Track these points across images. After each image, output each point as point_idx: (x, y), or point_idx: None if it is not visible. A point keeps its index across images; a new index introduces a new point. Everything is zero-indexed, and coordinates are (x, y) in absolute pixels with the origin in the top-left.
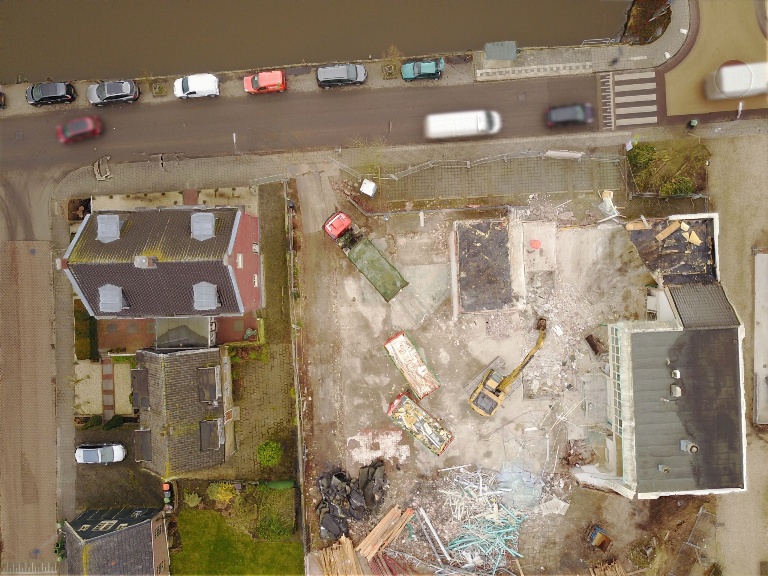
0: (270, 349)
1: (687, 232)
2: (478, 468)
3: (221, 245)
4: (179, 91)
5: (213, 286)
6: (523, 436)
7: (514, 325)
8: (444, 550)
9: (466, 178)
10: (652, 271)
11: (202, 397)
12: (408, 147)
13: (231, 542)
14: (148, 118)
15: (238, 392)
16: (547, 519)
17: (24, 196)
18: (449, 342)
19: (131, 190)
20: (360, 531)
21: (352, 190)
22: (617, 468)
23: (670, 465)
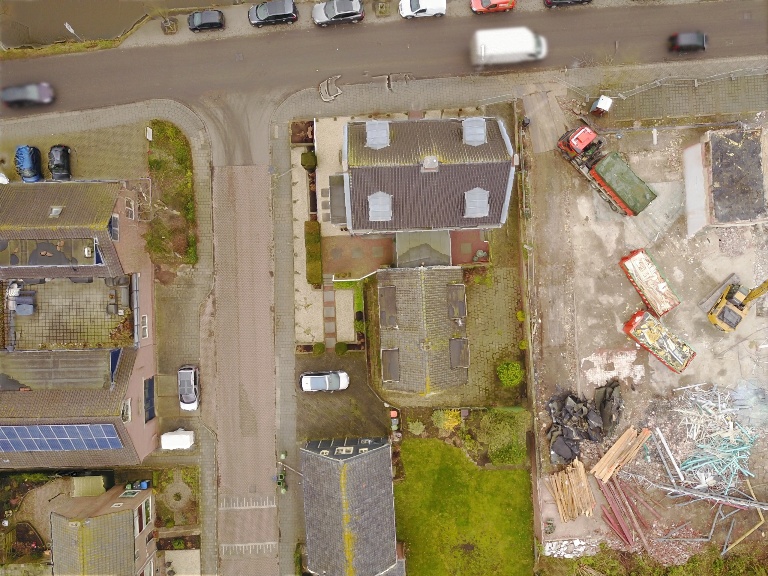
0: (494, 273)
1: None
2: (714, 386)
3: (497, 149)
4: (407, 10)
5: (485, 193)
6: (757, 353)
7: (747, 242)
8: (679, 470)
9: (693, 97)
10: None
11: (451, 314)
12: (635, 66)
13: (455, 471)
14: (371, 39)
15: None
16: None
17: (243, 119)
18: (683, 260)
19: (355, 112)
20: (591, 454)
21: (581, 109)
22: None
23: None
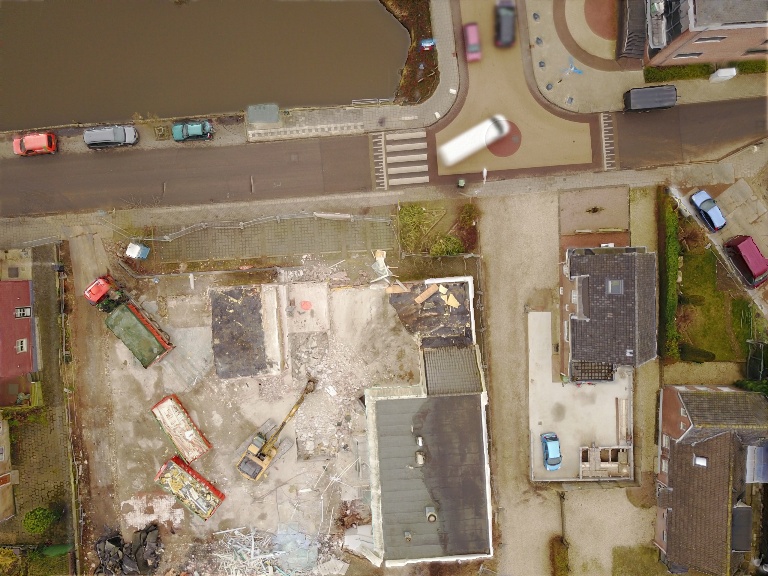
0: (49, 411)
1: (445, 295)
2: (252, 531)
3: None
4: None
5: None
6: (297, 498)
7: (286, 386)
8: None
9: (240, 239)
10: (412, 334)
11: None
12: (182, 208)
13: None
14: None
15: (17, 455)
16: None
17: None
18: (221, 404)
19: None
20: None
21: (124, 252)
22: None
23: (417, 532)
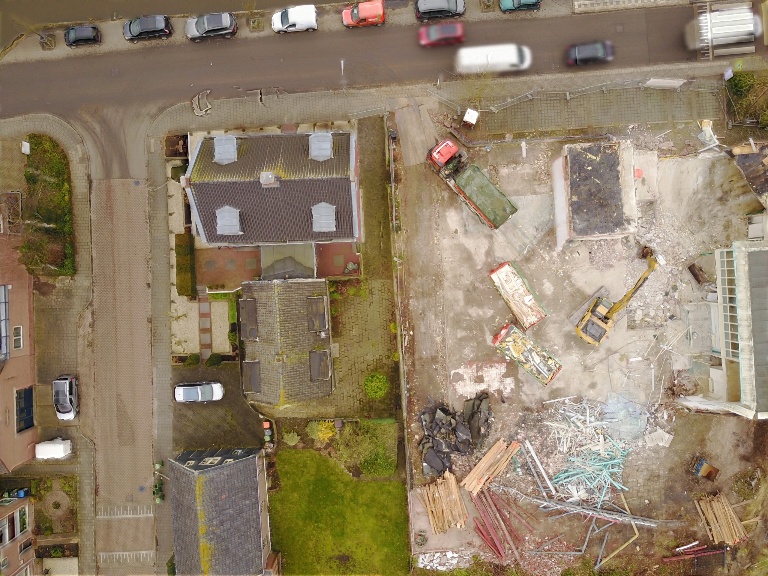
0: (368, 285)
1: None
2: (583, 399)
3: (341, 164)
4: (278, 25)
5: (332, 207)
6: (628, 366)
7: (617, 255)
8: (550, 483)
9: (565, 110)
10: (760, 195)
11: (311, 327)
12: (507, 79)
13: (330, 481)
14: (245, 53)
15: (337, 329)
16: (651, 451)
17: (120, 133)
18: (552, 273)
19: (229, 126)
20: (463, 466)
21: (452, 122)
22: (728, 394)
23: None
